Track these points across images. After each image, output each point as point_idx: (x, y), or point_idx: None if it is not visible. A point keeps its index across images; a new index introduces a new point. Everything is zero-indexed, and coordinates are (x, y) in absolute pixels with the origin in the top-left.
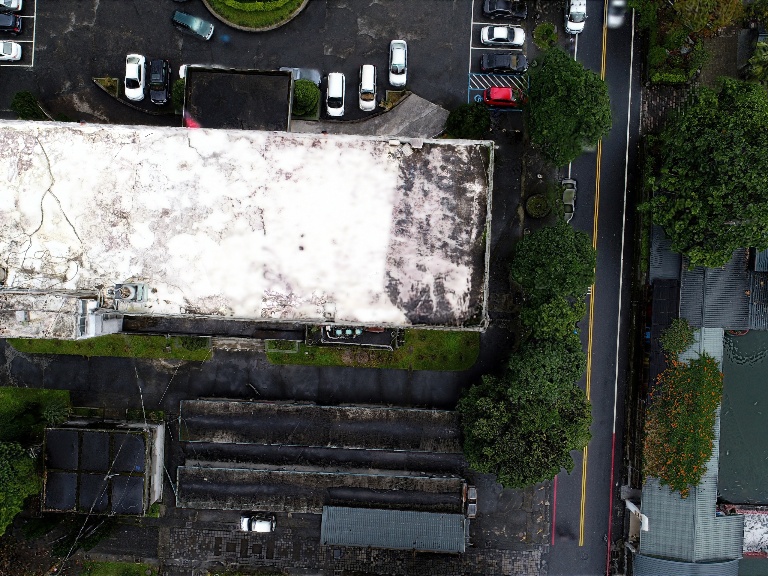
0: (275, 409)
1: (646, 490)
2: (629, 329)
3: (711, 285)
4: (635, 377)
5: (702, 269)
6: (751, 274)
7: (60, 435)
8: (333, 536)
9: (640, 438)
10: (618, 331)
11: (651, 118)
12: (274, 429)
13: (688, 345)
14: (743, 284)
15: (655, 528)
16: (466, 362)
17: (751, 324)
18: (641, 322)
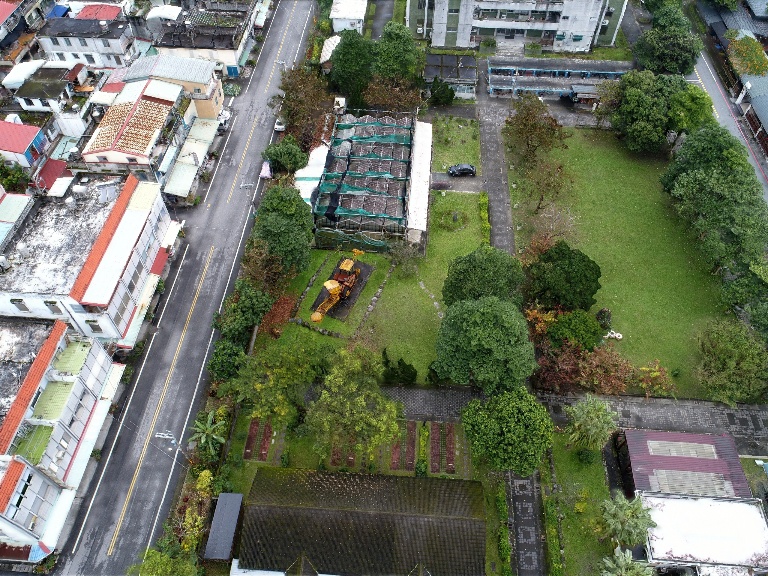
0: (537, 60)
1: (743, 78)
2: (706, 53)
3: (738, 19)
4: (717, 62)
5: (731, 15)
6: (755, 21)
7: (431, 56)
8: (580, 91)
9: (730, 74)
10: (701, 53)
11: (685, 1)
12: (537, 66)
13: (737, 35)
14: (753, 23)
15: (755, 88)
16: (628, 60)
17: (764, 35)
18: (711, 46)
